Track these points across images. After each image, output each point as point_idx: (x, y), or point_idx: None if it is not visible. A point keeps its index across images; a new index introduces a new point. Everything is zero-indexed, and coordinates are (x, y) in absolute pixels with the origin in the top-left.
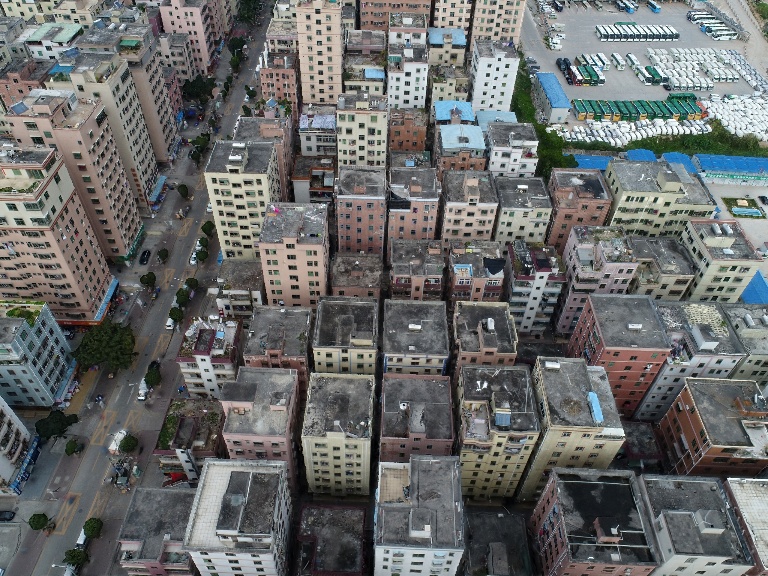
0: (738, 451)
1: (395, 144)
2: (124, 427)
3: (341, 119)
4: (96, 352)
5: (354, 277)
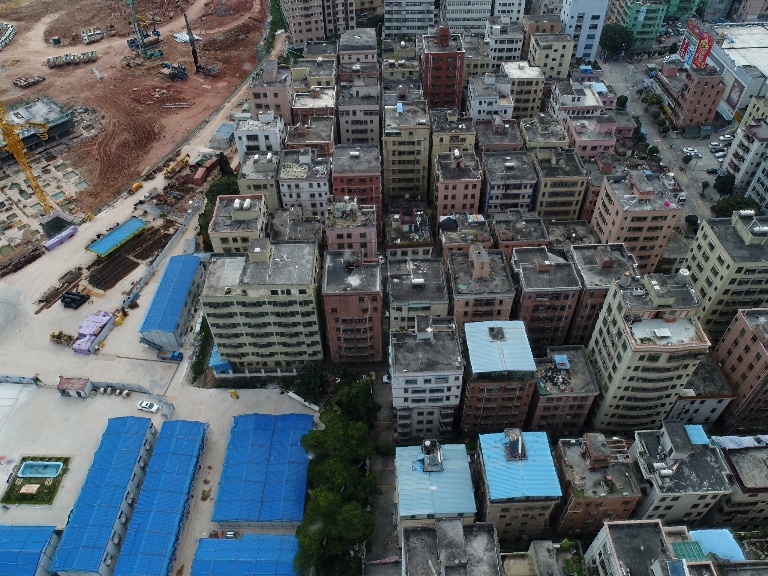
0: None
1: None
2: (687, 207)
3: None
4: None
5: None
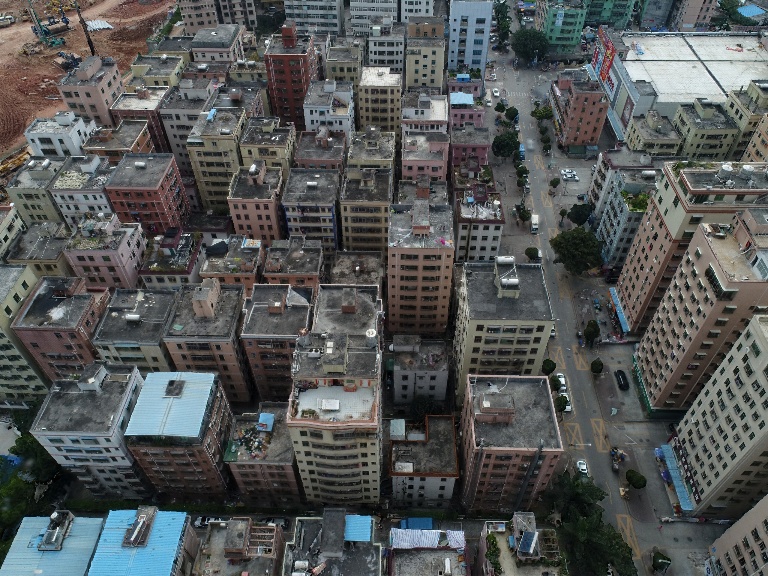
0: None
1: None
2: (539, 237)
3: None
4: None
5: None
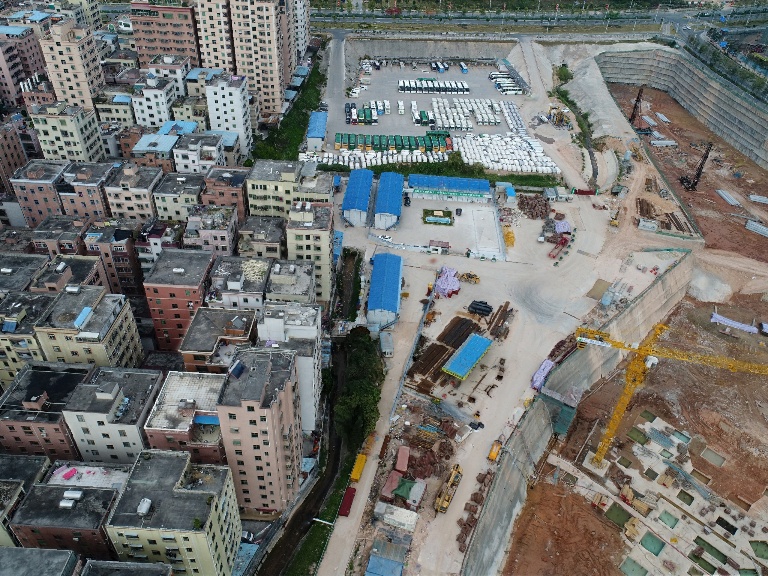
0: (207, 358)
1: (128, 155)
2: None
3: (36, 122)
4: None
5: (9, 244)
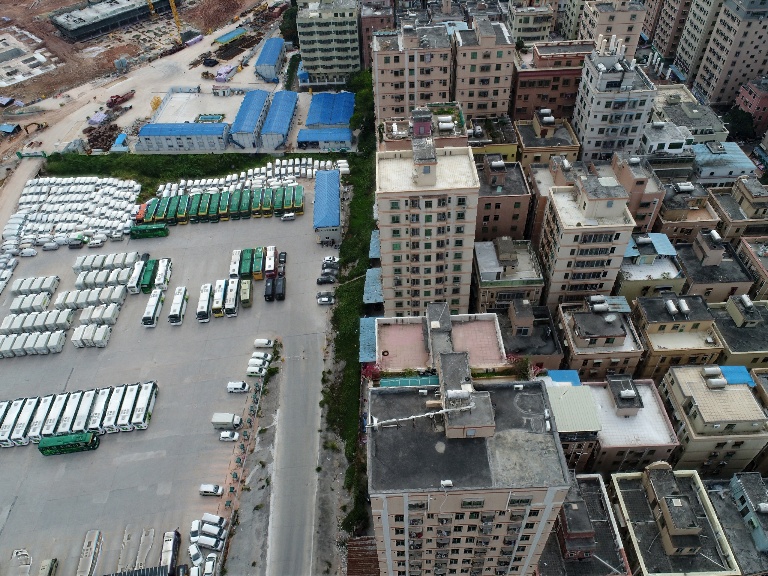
0: None
1: None
2: None
3: None
4: None
5: None
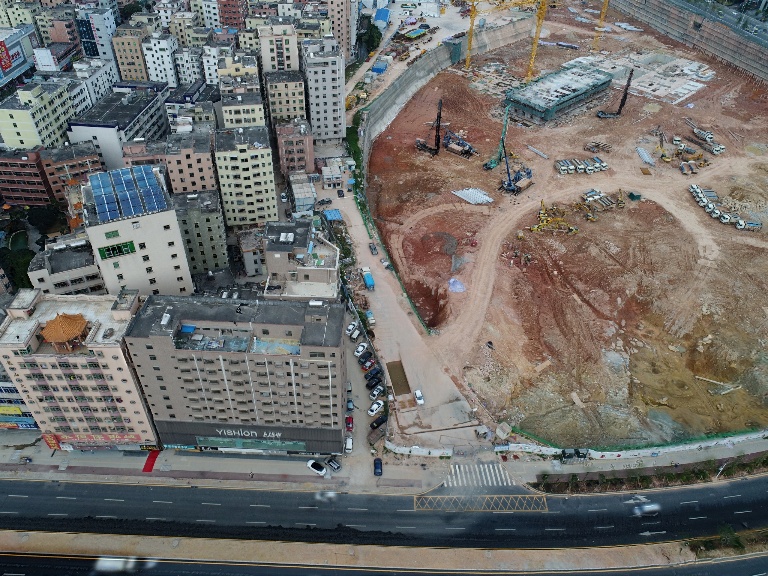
0: None
1: None
2: None
3: None
4: (129, 8)
5: None
